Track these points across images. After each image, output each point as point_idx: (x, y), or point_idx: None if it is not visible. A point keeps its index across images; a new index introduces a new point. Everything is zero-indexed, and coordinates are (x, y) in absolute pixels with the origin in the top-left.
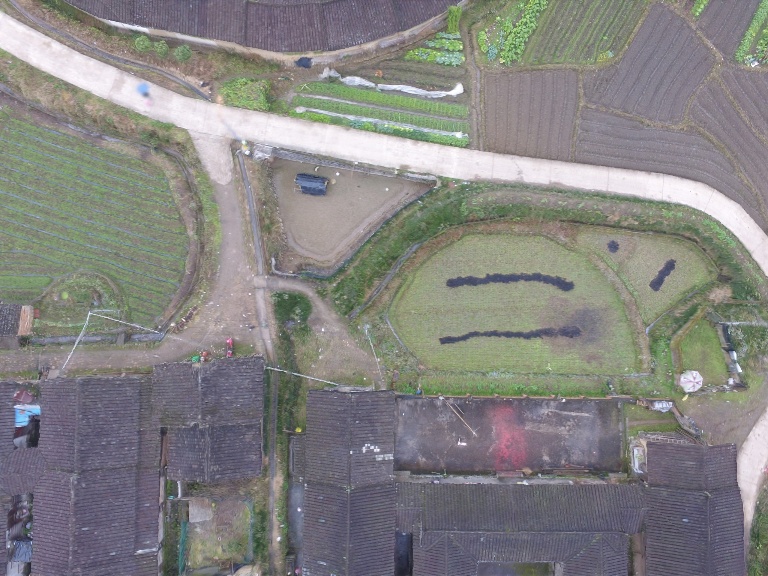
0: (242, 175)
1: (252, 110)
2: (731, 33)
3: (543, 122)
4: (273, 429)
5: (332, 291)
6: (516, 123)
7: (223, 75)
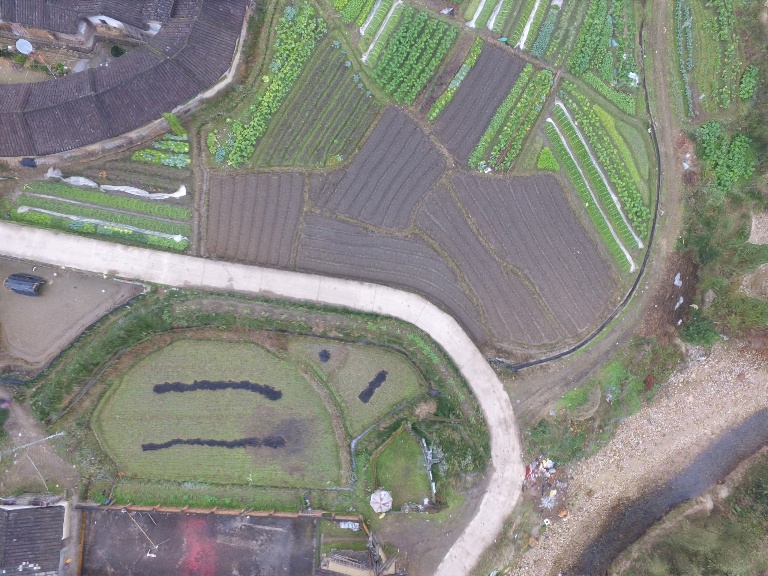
0: None
1: None
2: (467, 138)
3: (265, 226)
4: None
5: (30, 396)
6: (238, 226)
7: None
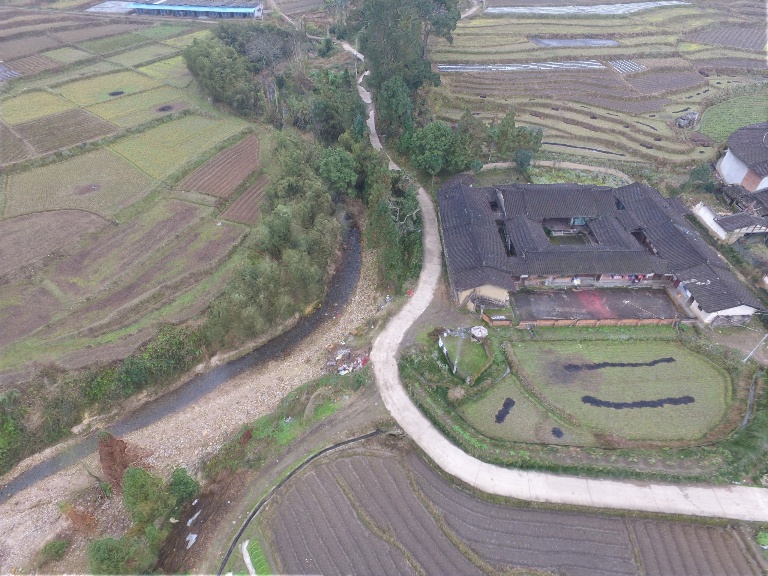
0: None
1: None
2: None
3: (683, 571)
4: (767, 300)
5: None
6: (715, 568)
7: None
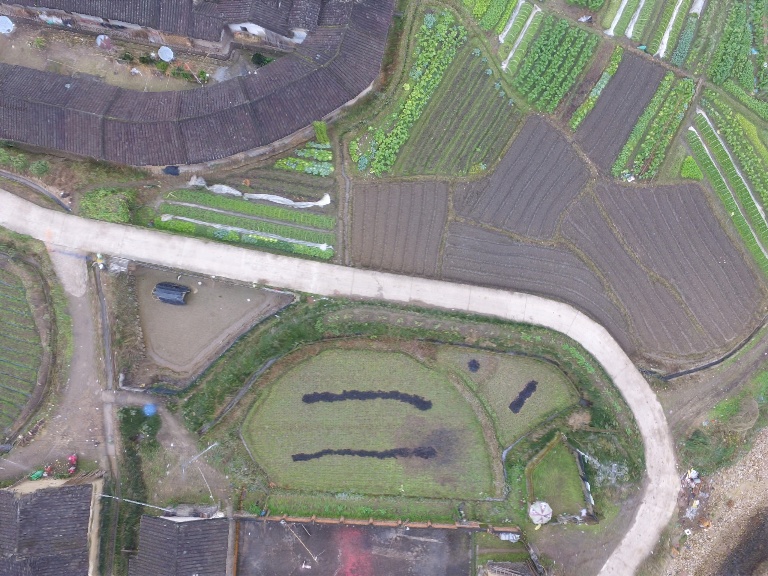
0: (97, 287)
1: (110, 222)
2: (609, 146)
3: (410, 235)
4: (112, 548)
5: (182, 406)
6: (382, 235)
7: (85, 185)
